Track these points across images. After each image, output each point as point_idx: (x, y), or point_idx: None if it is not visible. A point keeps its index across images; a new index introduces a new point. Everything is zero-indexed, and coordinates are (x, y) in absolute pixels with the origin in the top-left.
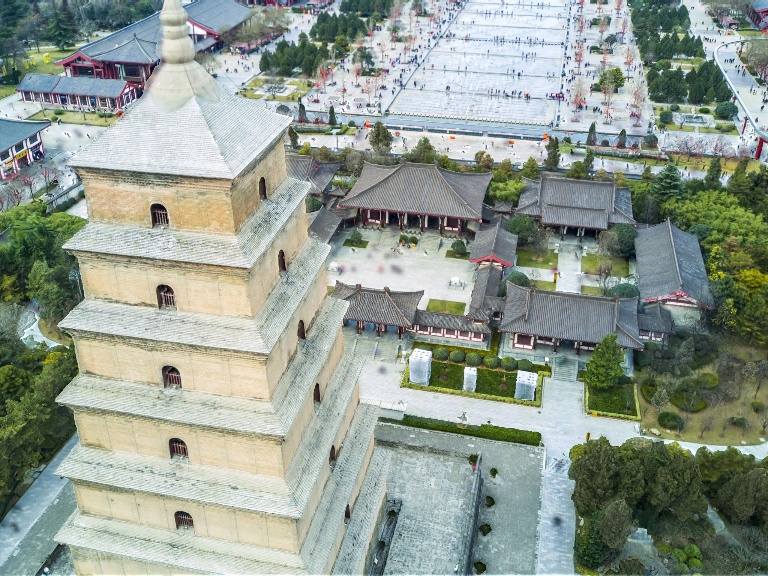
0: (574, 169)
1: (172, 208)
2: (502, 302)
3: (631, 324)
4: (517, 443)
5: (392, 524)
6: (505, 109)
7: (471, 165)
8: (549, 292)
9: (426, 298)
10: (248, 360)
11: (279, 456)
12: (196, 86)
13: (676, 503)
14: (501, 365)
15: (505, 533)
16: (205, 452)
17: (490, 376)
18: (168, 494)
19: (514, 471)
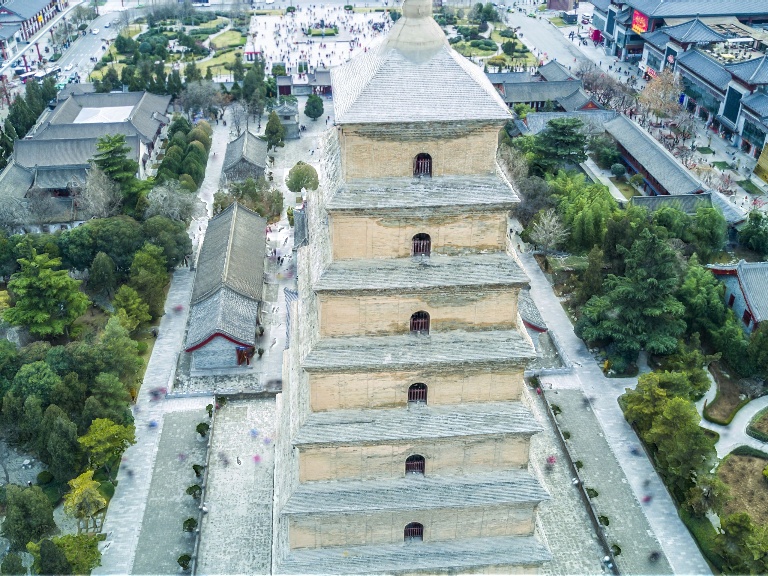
0: None
1: None
2: None
3: None
4: None
5: None
6: None
7: None
8: None
9: None
10: None
11: None
12: None
13: None
14: None
15: None
16: None
17: None
18: None
19: None
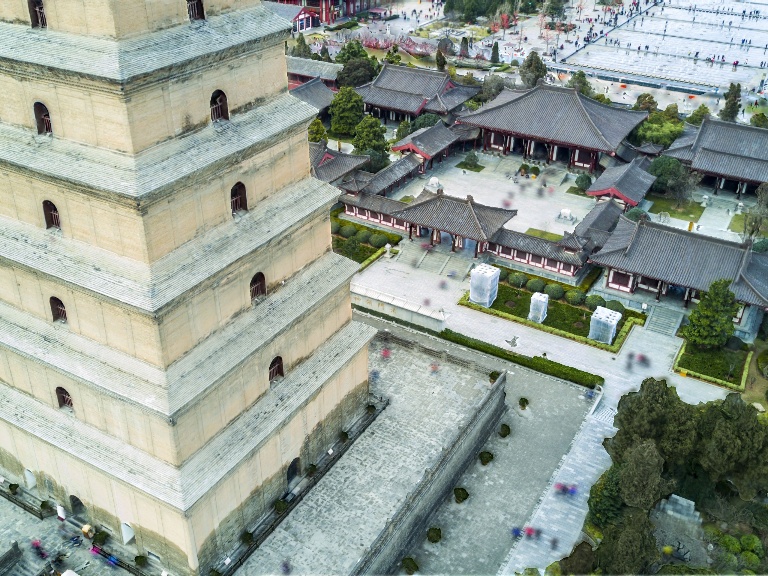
0: (754, 122)
1: None
2: (608, 237)
3: (763, 280)
4: (568, 381)
5: (367, 420)
6: (701, 72)
7: (630, 108)
8: (663, 226)
9: (525, 226)
10: (107, 94)
11: (142, 232)
12: None
13: (739, 474)
14: (585, 302)
15: (511, 468)
16: (75, 222)
17: (567, 311)
18: (33, 267)
19: (551, 408)
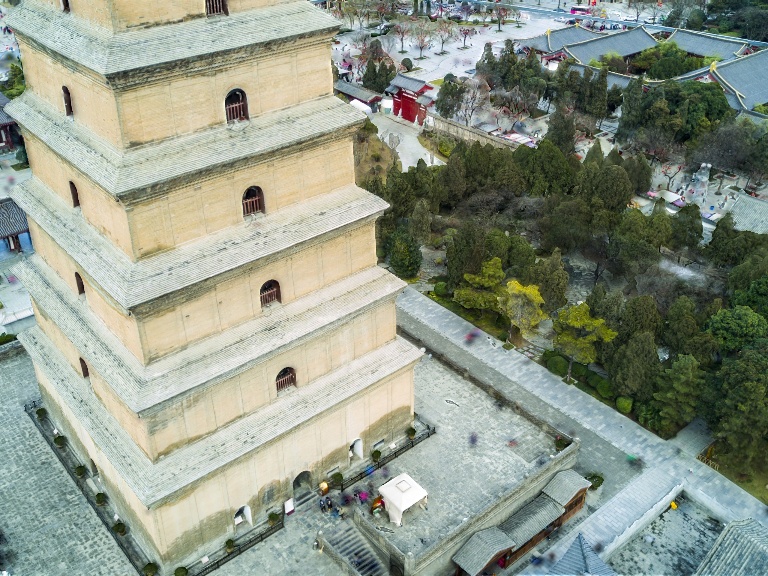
0: None
1: None
2: None
3: None
4: None
5: None
6: None
7: None
8: None
9: None
10: (316, 46)
11: None
12: None
13: None
14: None
15: None
16: (282, 190)
17: None
18: (268, 254)
19: None
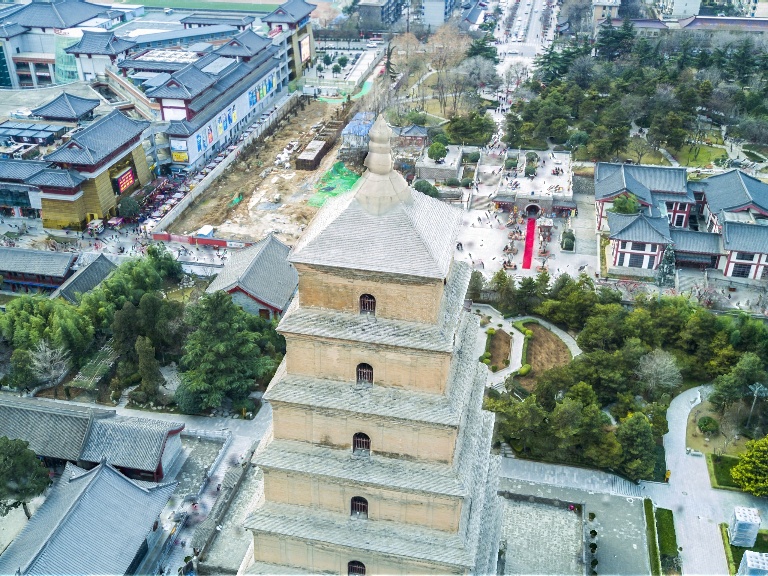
0: None
1: None
2: None
3: None
4: None
5: None
6: None
7: None
8: None
9: None
10: None
11: None
12: (363, 192)
13: None
14: None
15: None
16: None
17: None
18: None
19: None
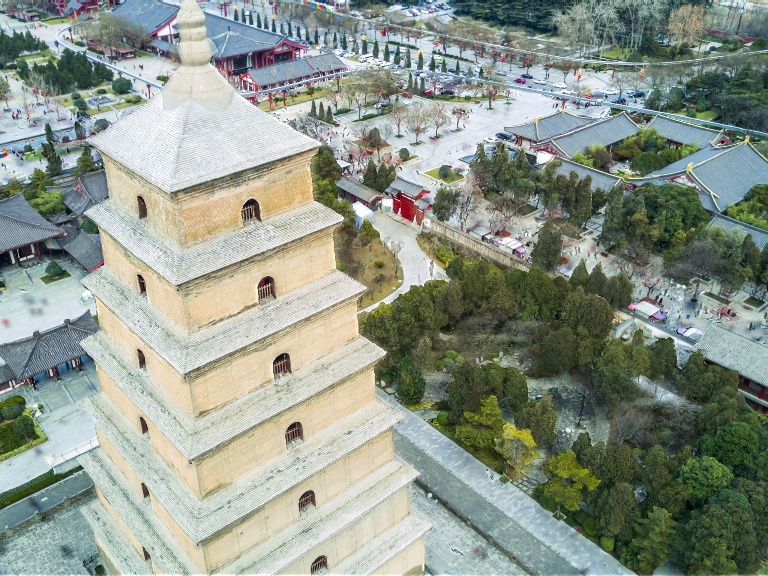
0: (84, 164)
1: (264, 198)
2: None
3: None
4: None
5: None
6: None
7: None
8: None
9: None
10: (346, 307)
11: (373, 381)
12: None
13: None
14: None
15: None
16: (317, 420)
17: None
18: None
19: None
